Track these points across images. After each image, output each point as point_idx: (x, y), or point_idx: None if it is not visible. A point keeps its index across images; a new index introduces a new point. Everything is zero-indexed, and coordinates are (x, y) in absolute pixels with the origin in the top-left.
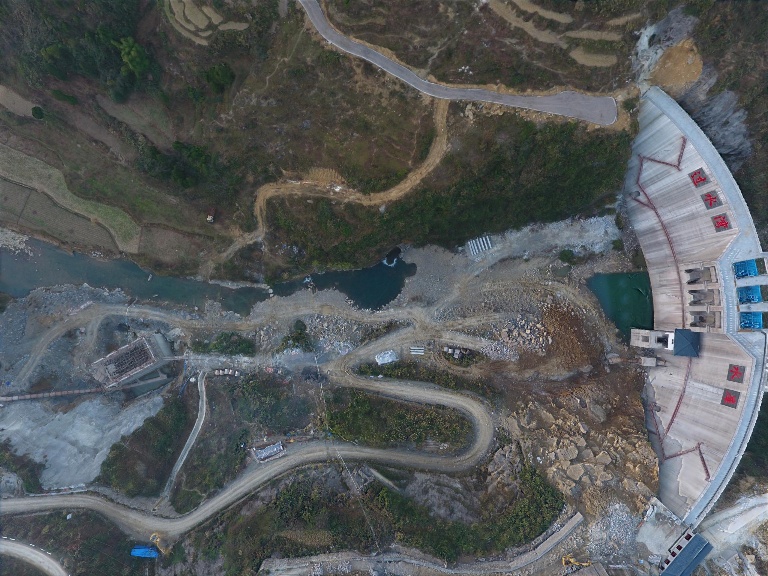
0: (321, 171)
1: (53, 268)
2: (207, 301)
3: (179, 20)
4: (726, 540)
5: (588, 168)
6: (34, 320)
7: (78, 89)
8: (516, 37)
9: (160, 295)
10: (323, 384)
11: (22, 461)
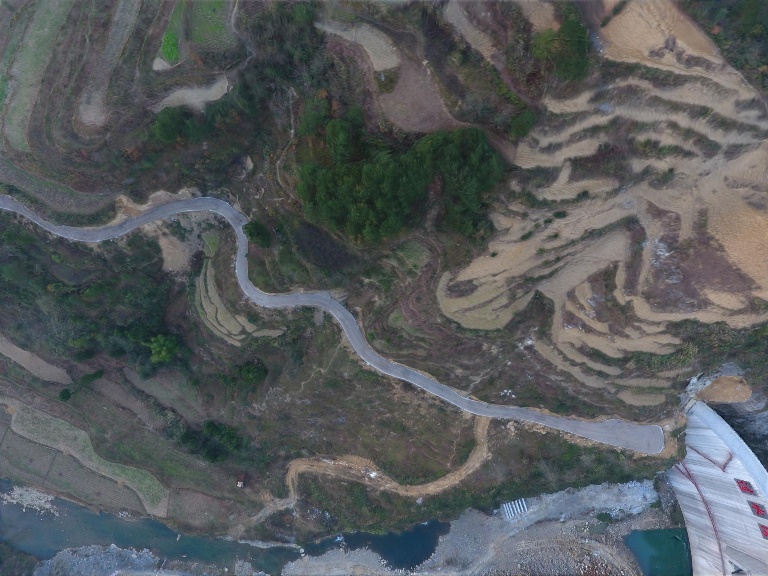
0: (356, 457)
1: (79, 528)
2: (237, 561)
3: (211, 320)
4: None
5: None
6: None
7: (105, 361)
8: (562, 376)
9: (189, 555)
10: None
11: None
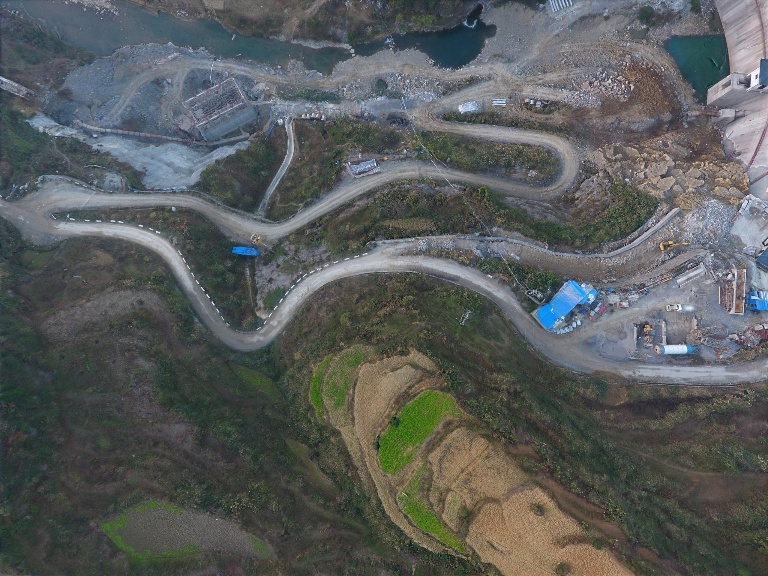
0: None
1: (138, 28)
2: (290, 60)
3: None
4: None
5: None
6: (123, 67)
7: None
8: None
9: (243, 55)
10: (408, 128)
11: (124, 166)
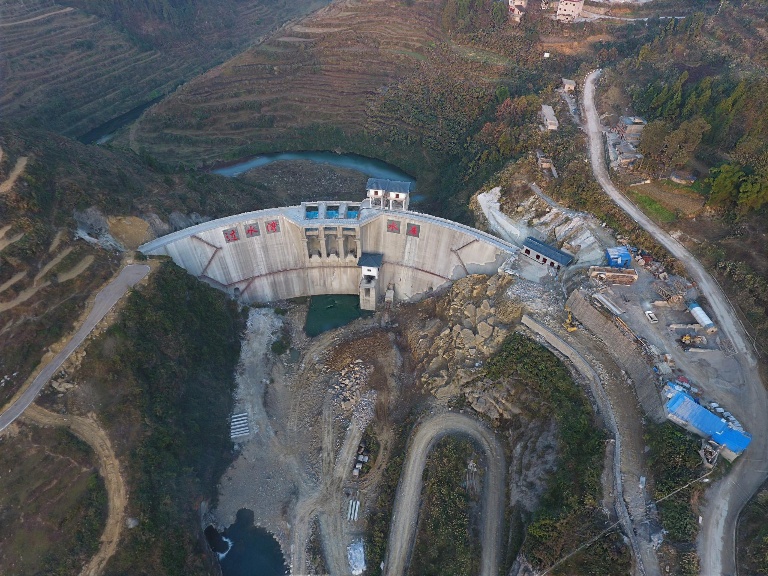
0: None
1: None
2: None
3: None
4: (526, 234)
5: (189, 304)
6: None
7: None
8: (6, 321)
9: None
10: None
11: None
